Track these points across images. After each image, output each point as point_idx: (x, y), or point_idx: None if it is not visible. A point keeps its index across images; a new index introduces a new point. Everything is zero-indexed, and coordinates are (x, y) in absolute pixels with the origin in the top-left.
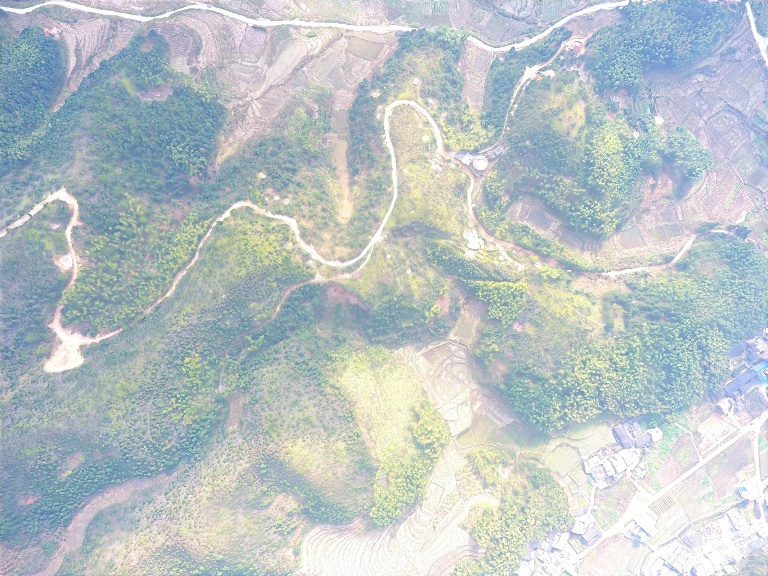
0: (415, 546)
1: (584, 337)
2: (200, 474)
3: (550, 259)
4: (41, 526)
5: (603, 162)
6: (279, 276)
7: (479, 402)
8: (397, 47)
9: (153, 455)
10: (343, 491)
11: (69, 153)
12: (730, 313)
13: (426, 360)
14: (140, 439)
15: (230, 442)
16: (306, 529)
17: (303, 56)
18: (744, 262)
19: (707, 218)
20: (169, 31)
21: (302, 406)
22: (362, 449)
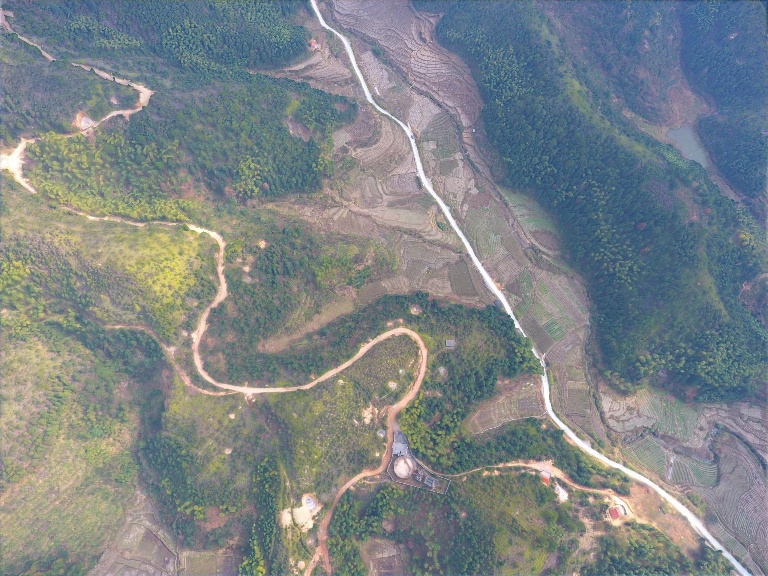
0: None
1: None
2: None
3: None
4: None
5: None
6: (148, 308)
7: None
8: (480, 308)
9: None
10: None
11: (196, 87)
12: None
13: (142, 538)
14: None
15: None
16: None
17: (415, 228)
18: None
19: None
20: (367, 117)
21: (1, 409)
22: None
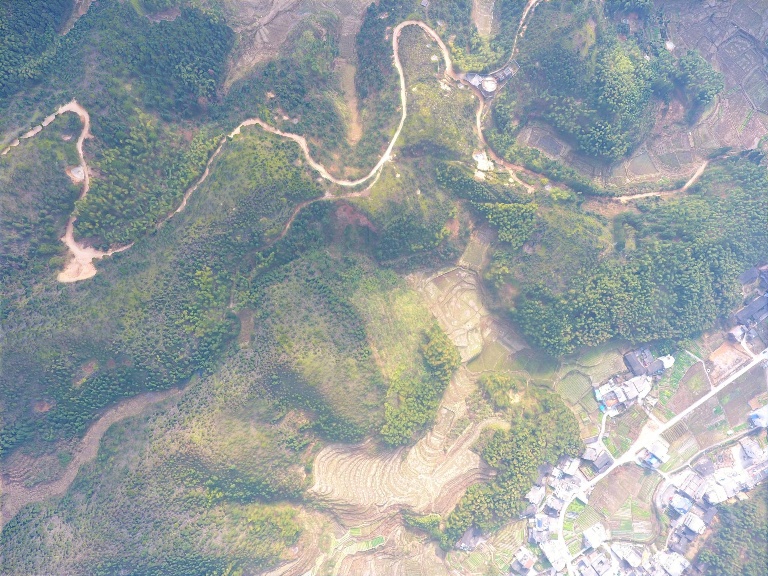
0: (426, 469)
1: (595, 256)
2: (212, 386)
3: (560, 183)
4: (56, 435)
5: (614, 81)
6: (289, 191)
7: (489, 329)
8: None
9: (166, 366)
10: (354, 406)
11: (79, 68)
12: (743, 233)
13: (436, 286)
14: (153, 348)
15: (242, 355)
16: (318, 447)
17: None
18: (757, 183)
19: (719, 145)
20: None
21: (313, 321)
22: (373, 366)
